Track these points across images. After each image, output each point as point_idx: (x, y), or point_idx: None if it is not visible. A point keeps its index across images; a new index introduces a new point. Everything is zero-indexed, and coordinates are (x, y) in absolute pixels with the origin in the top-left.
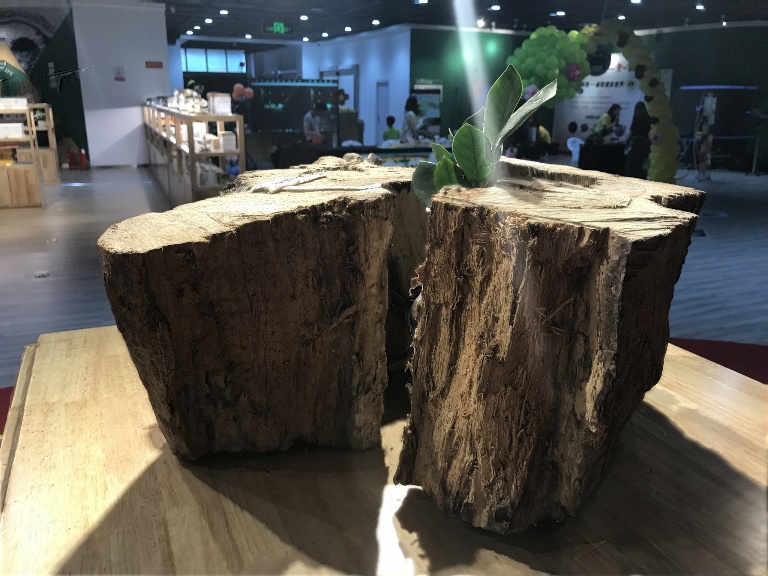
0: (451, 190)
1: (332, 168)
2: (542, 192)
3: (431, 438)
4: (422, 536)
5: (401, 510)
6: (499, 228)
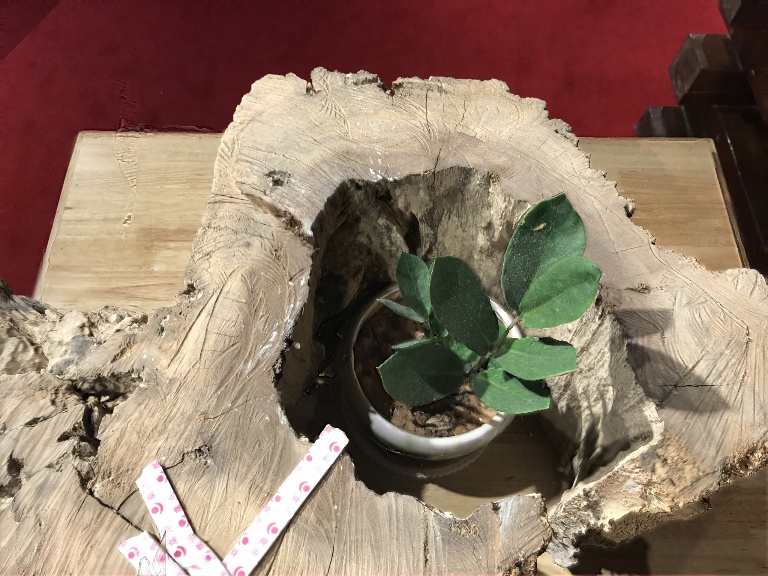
0: (661, 468)
1: (81, 423)
2: (692, 374)
3: (596, 535)
4: (608, 566)
5: (569, 566)
6: (749, 471)
